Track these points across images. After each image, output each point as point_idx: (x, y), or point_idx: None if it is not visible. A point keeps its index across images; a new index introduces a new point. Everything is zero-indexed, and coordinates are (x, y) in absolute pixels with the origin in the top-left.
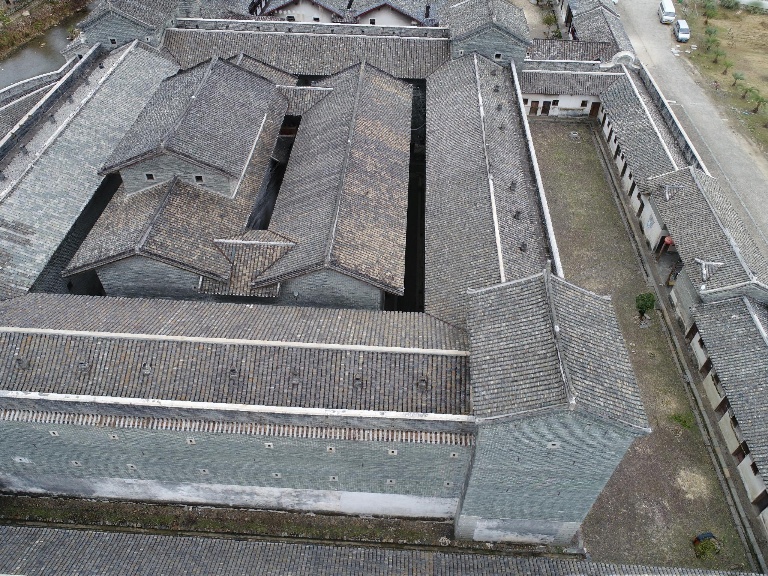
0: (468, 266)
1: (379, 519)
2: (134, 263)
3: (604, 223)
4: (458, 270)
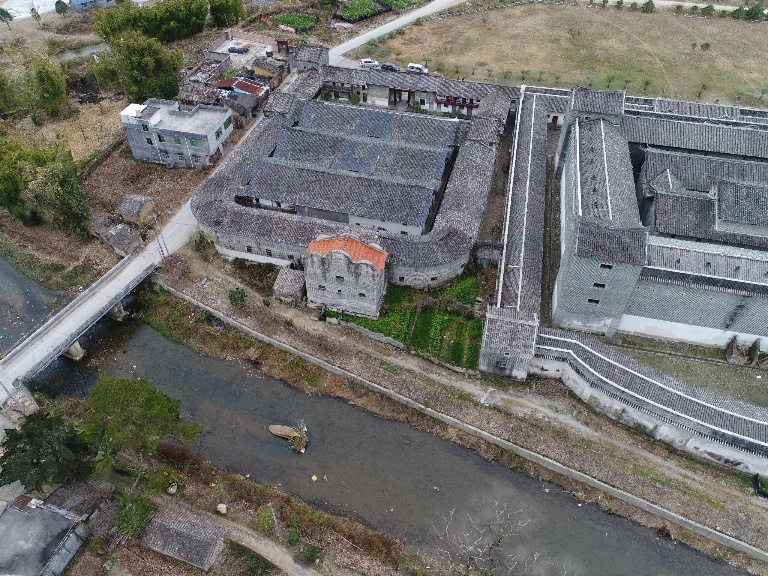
0: None
1: None
2: None
3: None
4: None
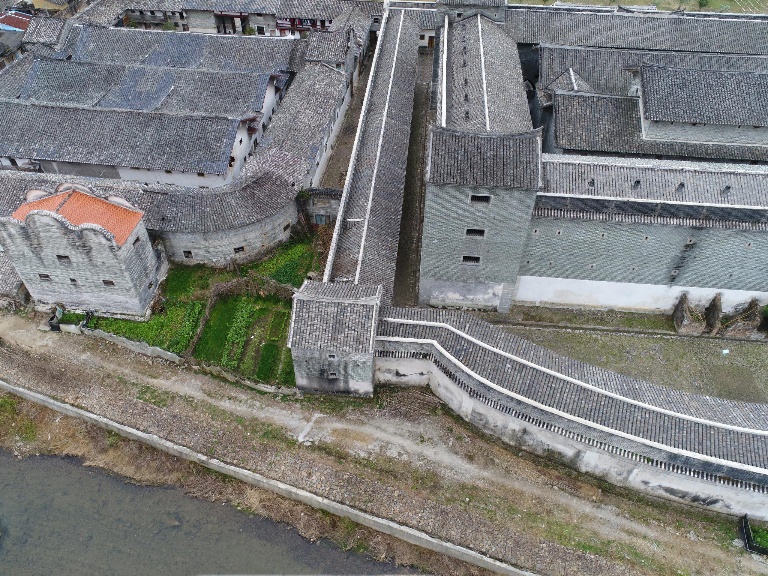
0: (761, 34)
1: None
2: None
3: None
4: (763, 39)
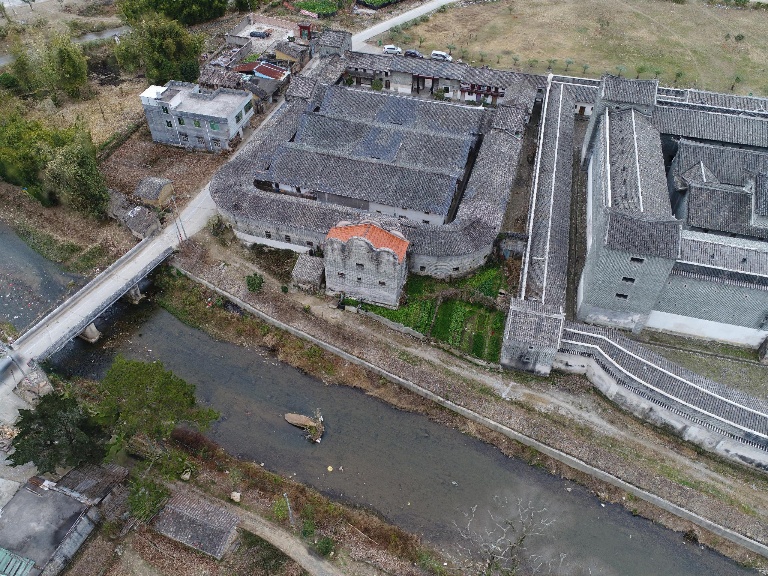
0: None
1: None
2: None
3: None
4: None
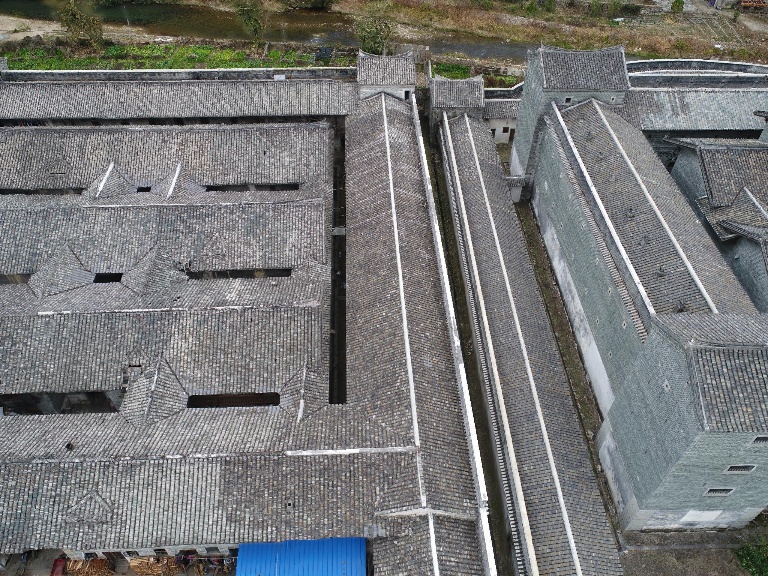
0: None
1: (590, 388)
2: (695, 161)
3: None
4: None
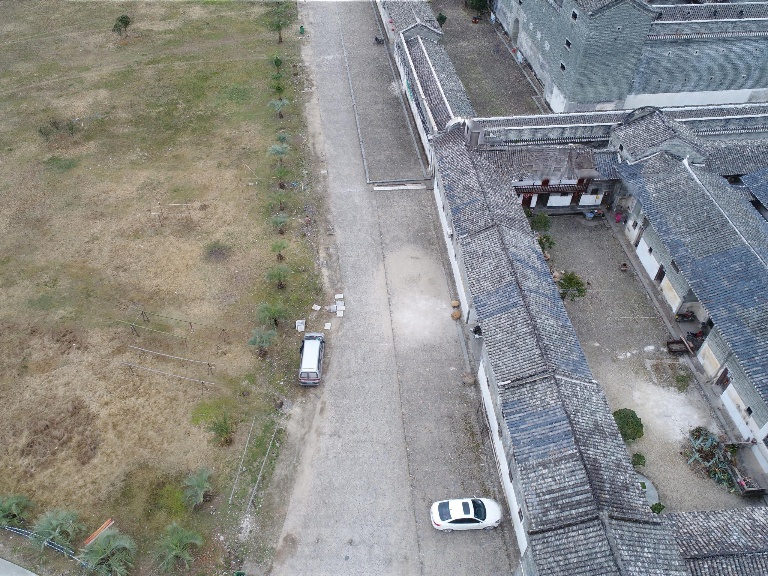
0: None
1: None
2: None
3: (458, 71)
4: None
